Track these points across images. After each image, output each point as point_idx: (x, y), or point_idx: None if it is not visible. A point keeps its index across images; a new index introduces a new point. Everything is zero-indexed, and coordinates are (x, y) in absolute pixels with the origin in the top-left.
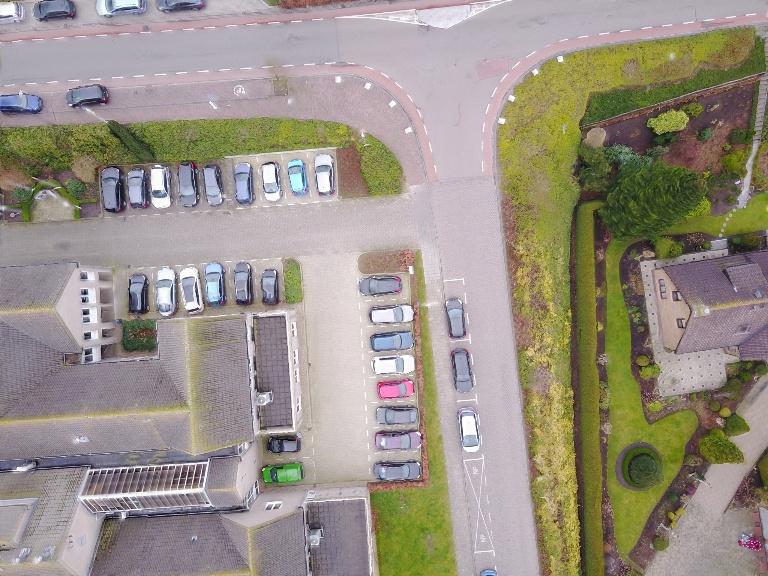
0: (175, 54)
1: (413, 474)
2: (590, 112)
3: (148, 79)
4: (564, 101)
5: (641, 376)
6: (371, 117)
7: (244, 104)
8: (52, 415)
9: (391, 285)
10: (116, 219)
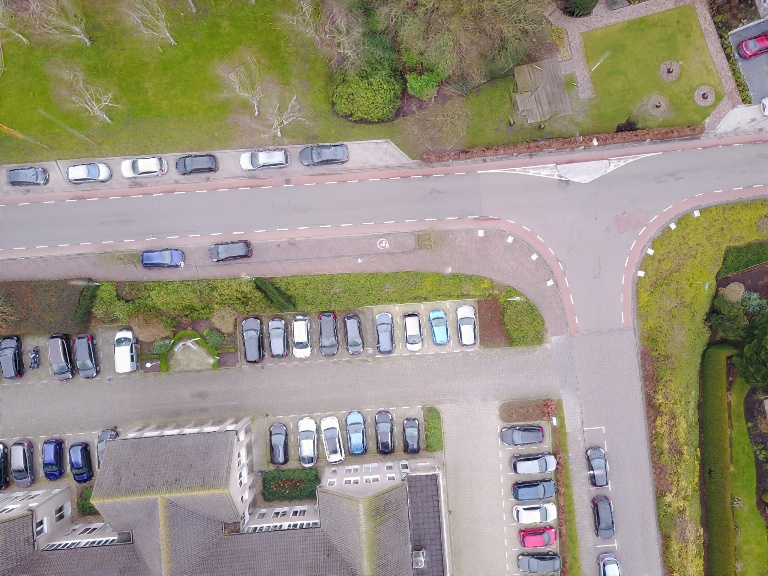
0: (319, 208)
1: None
2: (726, 265)
3: (292, 232)
4: (702, 255)
5: (767, 512)
6: (514, 270)
7: (388, 258)
8: None
9: (536, 436)
10: (254, 368)
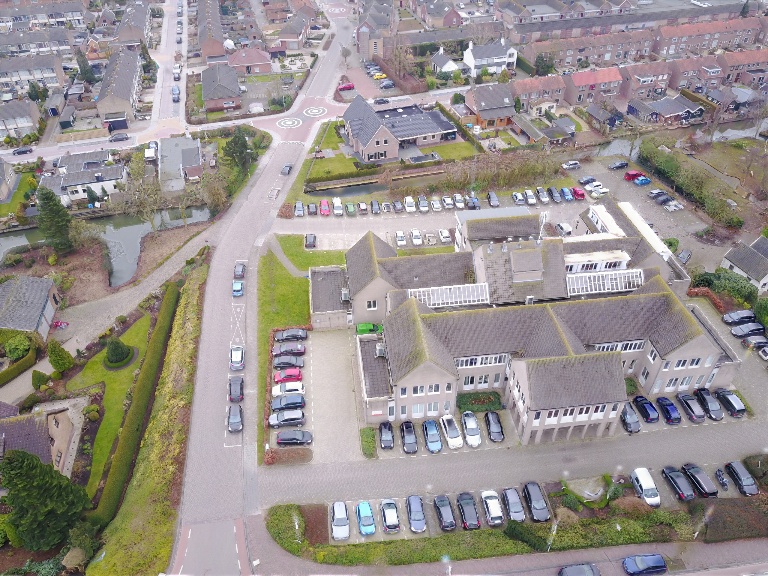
0: None
1: (280, 333)
2: None
3: None
4: None
5: (99, 407)
6: (292, 573)
7: None
8: (511, 310)
9: (285, 434)
10: None
